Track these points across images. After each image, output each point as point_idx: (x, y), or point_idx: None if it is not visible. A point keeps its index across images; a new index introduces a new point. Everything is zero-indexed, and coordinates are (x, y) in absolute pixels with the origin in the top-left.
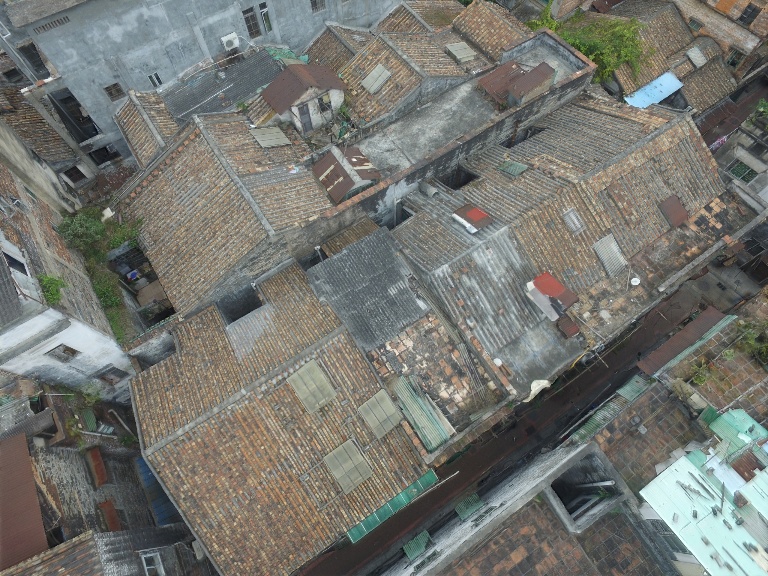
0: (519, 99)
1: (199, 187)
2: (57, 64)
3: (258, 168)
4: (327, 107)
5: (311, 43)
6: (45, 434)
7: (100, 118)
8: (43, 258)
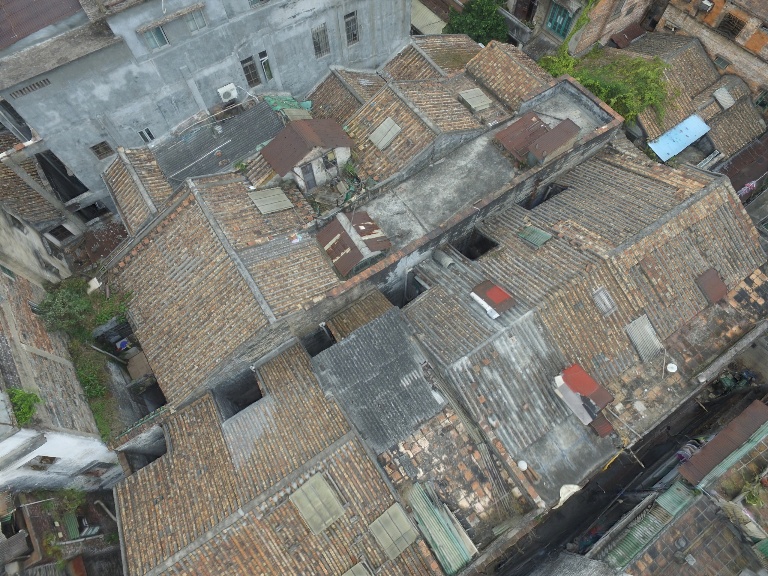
0: (541, 159)
1: (193, 261)
2: (38, 127)
3: (257, 239)
4: (332, 164)
5: (314, 88)
6: (19, 558)
7: (87, 177)
8: (17, 359)
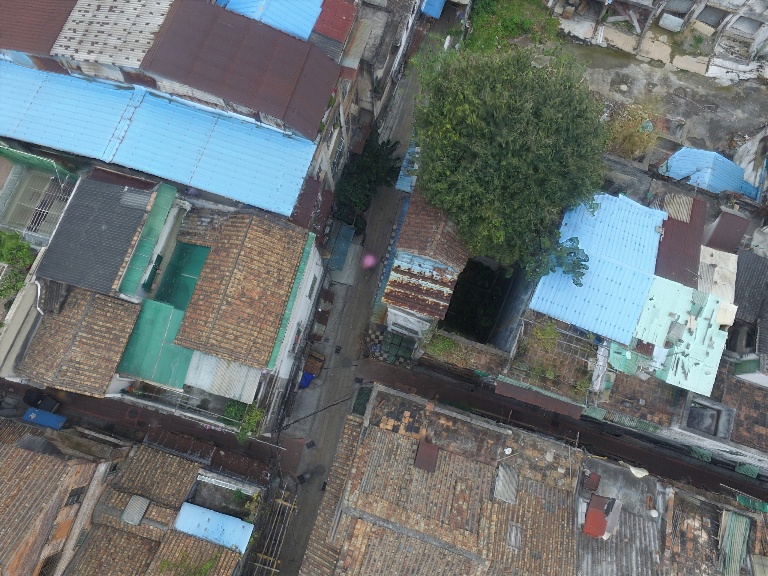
0: None
1: None
2: None
3: None
4: None
5: None
6: None
7: None
8: None
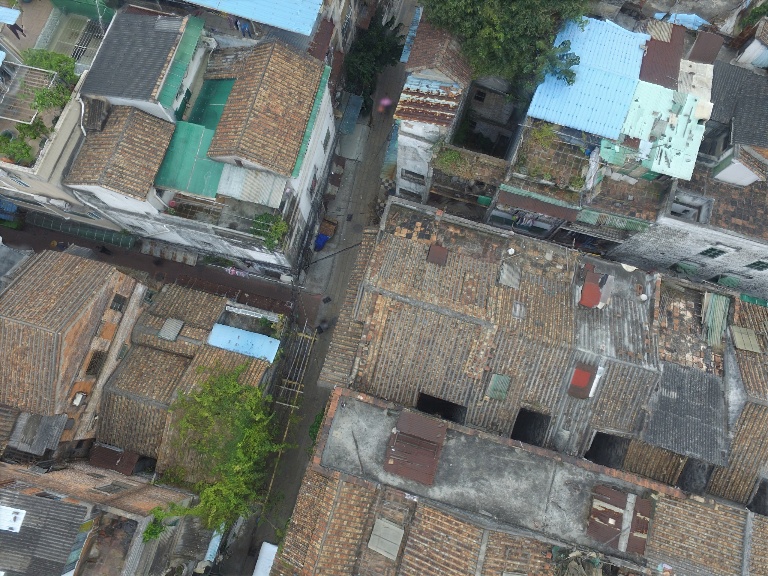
0: None
1: None
2: None
3: None
4: None
5: None
6: None
7: None
8: None
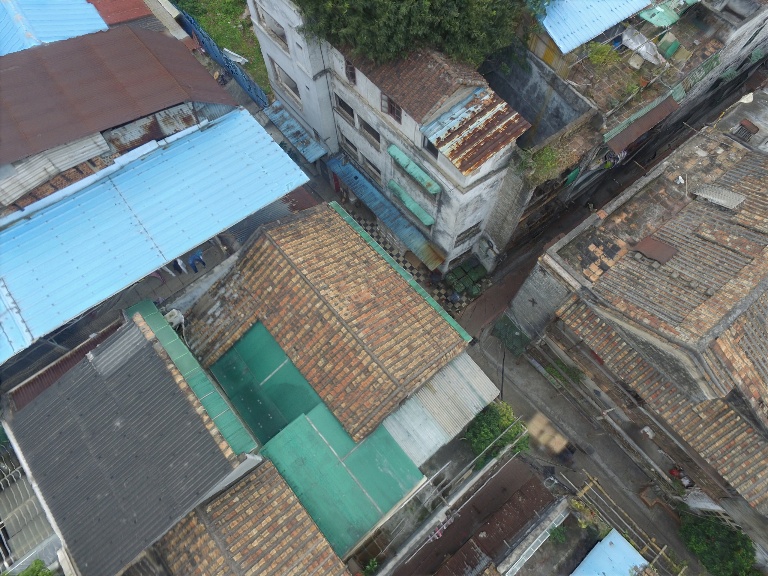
0: None
1: None
2: None
3: None
4: None
5: None
6: None
7: None
8: None
